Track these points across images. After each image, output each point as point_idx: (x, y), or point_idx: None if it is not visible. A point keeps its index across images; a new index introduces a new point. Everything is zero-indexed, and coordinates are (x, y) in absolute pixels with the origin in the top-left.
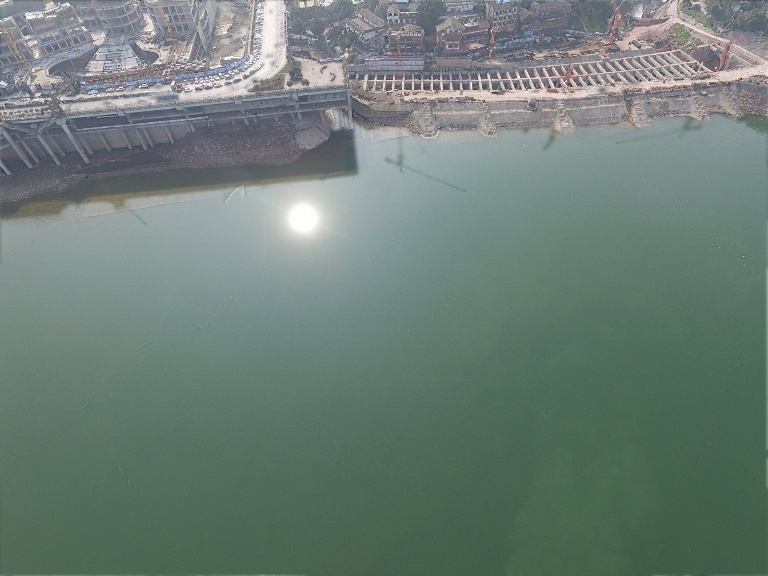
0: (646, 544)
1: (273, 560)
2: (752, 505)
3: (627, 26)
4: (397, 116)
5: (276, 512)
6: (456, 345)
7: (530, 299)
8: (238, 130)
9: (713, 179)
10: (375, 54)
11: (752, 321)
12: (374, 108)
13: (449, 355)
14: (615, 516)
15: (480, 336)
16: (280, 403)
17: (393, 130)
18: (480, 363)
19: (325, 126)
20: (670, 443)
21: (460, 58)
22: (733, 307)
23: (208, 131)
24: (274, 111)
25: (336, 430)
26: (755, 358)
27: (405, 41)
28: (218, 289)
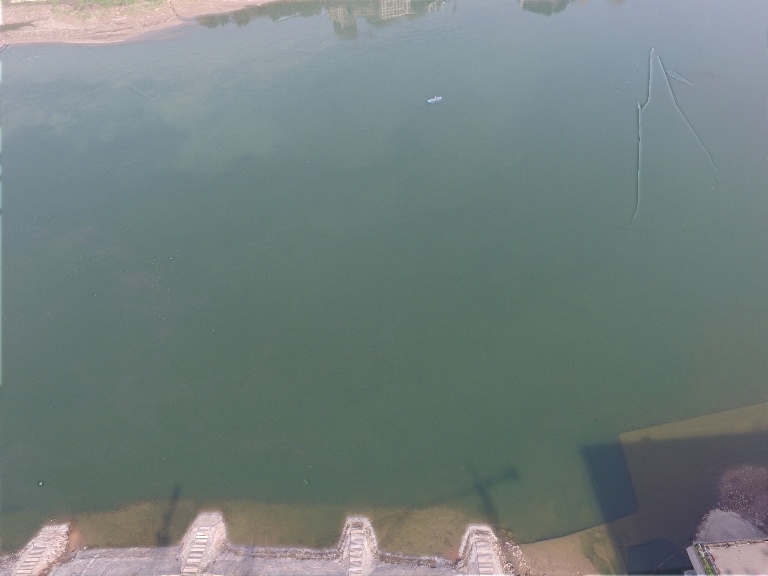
0: (369, 133)
1: (552, 133)
2: (307, 143)
3: None
4: None
5: (558, 150)
6: (456, 202)
7: (386, 238)
8: None
9: (83, 372)
10: None
11: (221, 212)
12: None
13: (462, 197)
14: (379, 140)
15: (437, 209)
16: (579, 189)
17: (560, 569)
18: (439, 194)
19: None
20: (332, 163)
21: None
22: None
23: None
24: None
25: (535, 177)
26: (243, 193)
27: None
28: (672, 208)
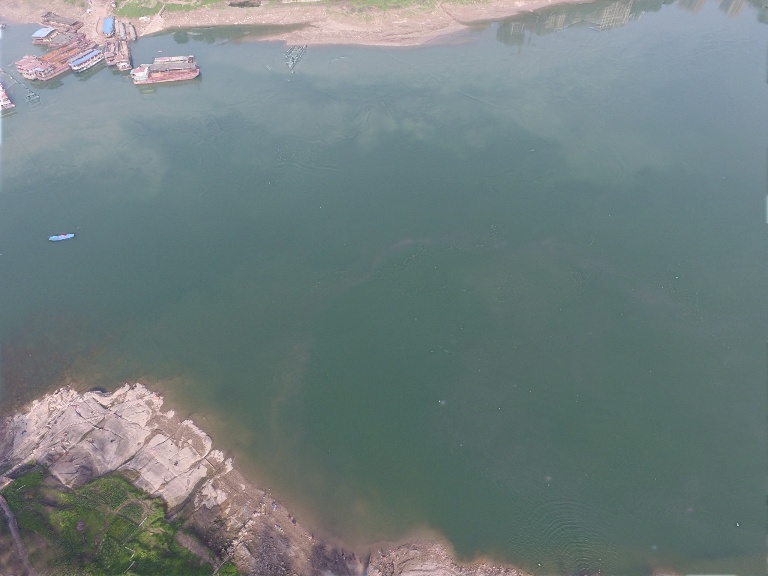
0: (765, 148)
1: None
2: (704, 157)
3: None
4: None
5: None
6: None
7: None
8: None
9: (682, 399)
10: None
11: (683, 229)
12: None
13: None
14: None
15: None
16: None
17: None
18: None
19: None
20: (750, 179)
21: None
22: (690, 246)
23: None
24: None
25: None
26: (686, 209)
27: None
28: None
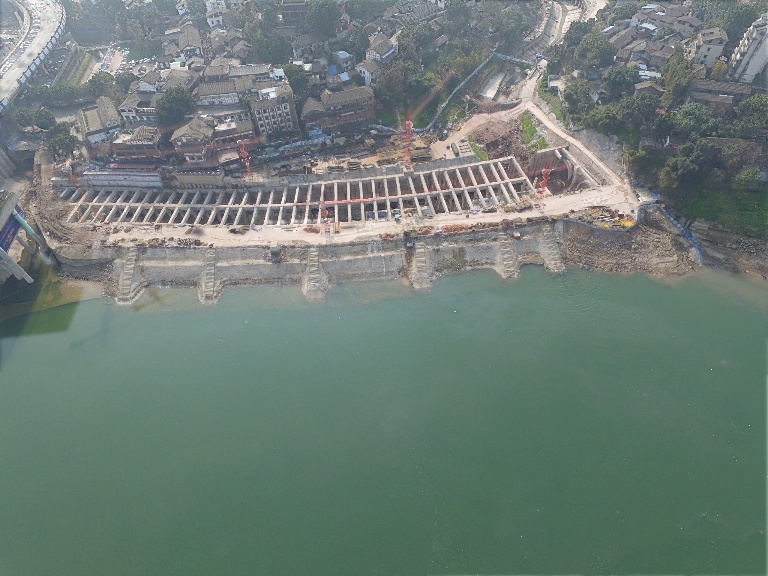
0: None
1: None
2: None
3: (464, 113)
4: (94, 265)
5: None
6: None
7: None
8: None
9: (480, 399)
10: (101, 164)
11: None
12: (63, 254)
13: None
14: None
15: None
16: None
17: (83, 287)
18: None
19: None
20: None
21: (205, 174)
22: None
23: None
24: None
25: None
26: None
27: (134, 149)
28: None
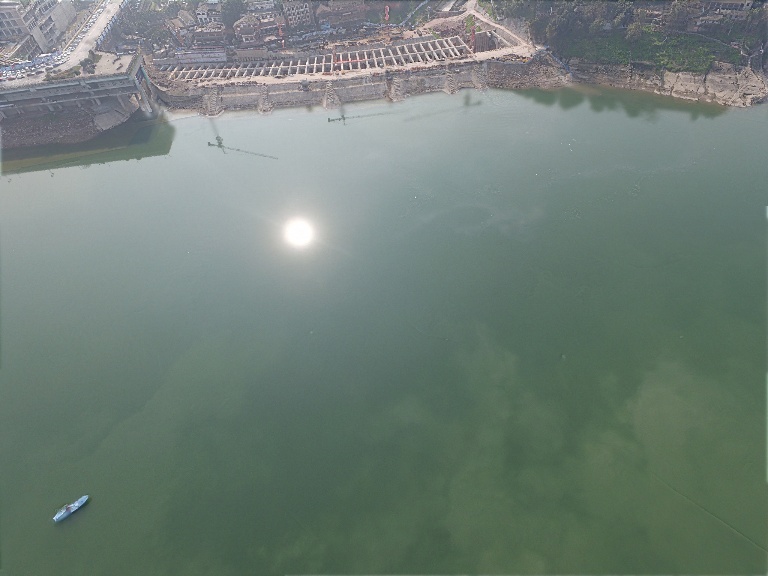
0: None
1: None
2: (319, 372)
3: (427, 18)
4: (190, 100)
5: None
6: (143, 270)
7: (227, 236)
8: (42, 115)
9: (431, 140)
10: None
11: (394, 244)
12: (170, 94)
13: (134, 278)
14: (208, 384)
15: (168, 264)
16: None
17: (185, 112)
18: (158, 283)
19: (126, 110)
20: (281, 333)
21: (256, 49)
22: (390, 236)
23: (17, 117)
24: (72, 98)
25: (26, 337)
26: (381, 271)
27: (208, 36)
28: None
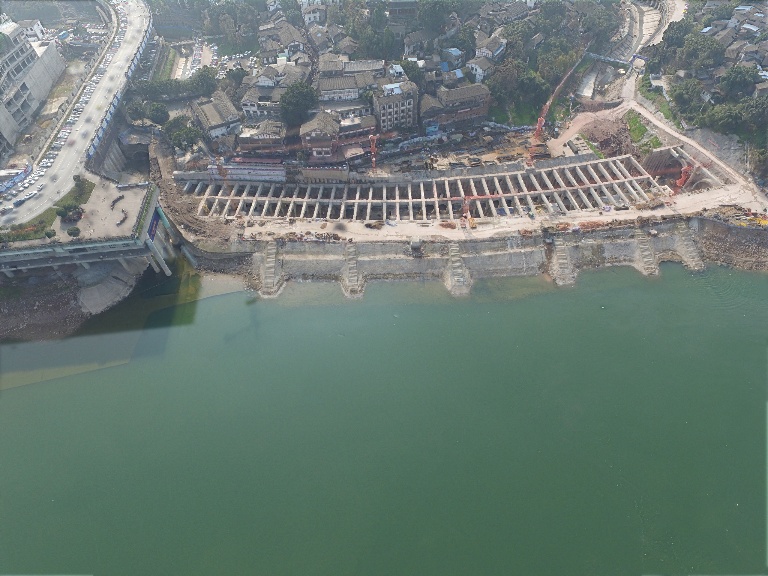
0: None
1: None
2: None
3: (569, 112)
4: (232, 258)
5: None
6: None
7: None
8: None
9: (651, 394)
10: None
11: None
12: (200, 247)
13: None
14: None
15: None
16: None
17: (223, 280)
18: None
19: (130, 273)
20: None
21: (332, 169)
22: None
23: None
24: (43, 262)
25: None
26: None
27: (260, 144)
28: None
